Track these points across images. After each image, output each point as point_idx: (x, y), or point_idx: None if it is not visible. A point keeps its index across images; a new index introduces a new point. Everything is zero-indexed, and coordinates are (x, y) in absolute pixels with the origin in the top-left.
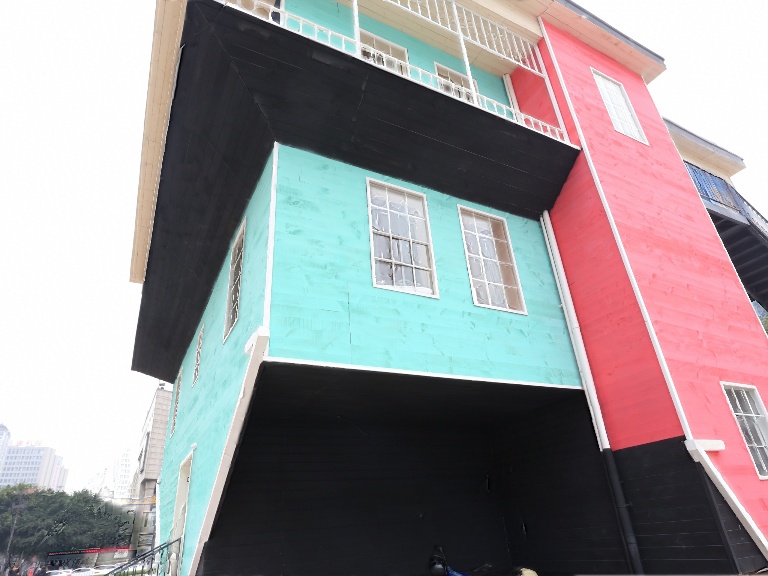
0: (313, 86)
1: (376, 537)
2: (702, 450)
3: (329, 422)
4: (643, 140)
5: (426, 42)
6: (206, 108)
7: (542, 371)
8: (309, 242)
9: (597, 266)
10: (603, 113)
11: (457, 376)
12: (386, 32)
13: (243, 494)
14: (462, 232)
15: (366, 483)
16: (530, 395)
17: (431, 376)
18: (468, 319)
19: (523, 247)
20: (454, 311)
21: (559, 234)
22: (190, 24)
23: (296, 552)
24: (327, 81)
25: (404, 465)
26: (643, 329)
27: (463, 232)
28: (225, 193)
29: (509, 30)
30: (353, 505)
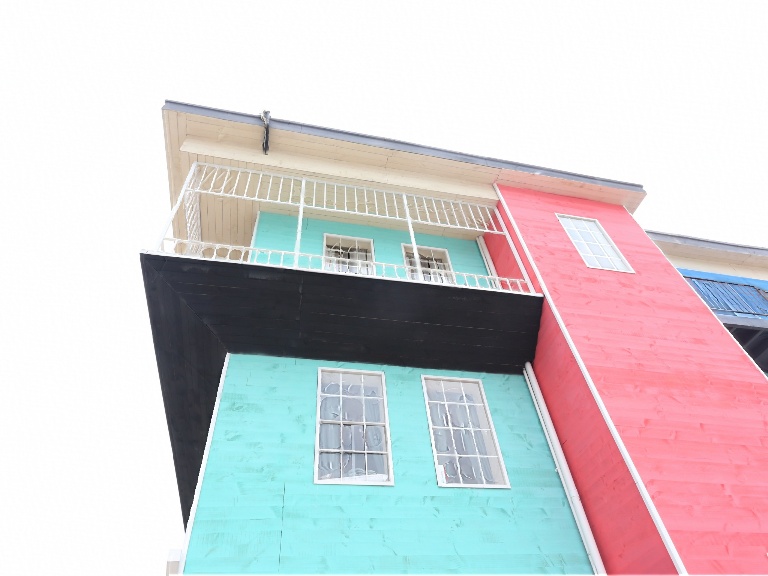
0: (254, 299)
1: None
2: None
3: None
4: (627, 269)
5: (393, 229)
6: (175, 334)
7: (534, 560)
8: (247, 446)
9: (581, 419)
10: (571, 254)
11: None
12: (353, 230)
13: None
14: (426, 404)
15: None
16: None
17: None
18: (431, 505)
19: (504, 407)
20: (413, 497)
21: (544, 386)
22: (147, 275)
23: None
24: (266, 293)
25: None
26: (636, 493)
27: (427, 404)
28: (209, 401)
29: (464, 202)
30: None
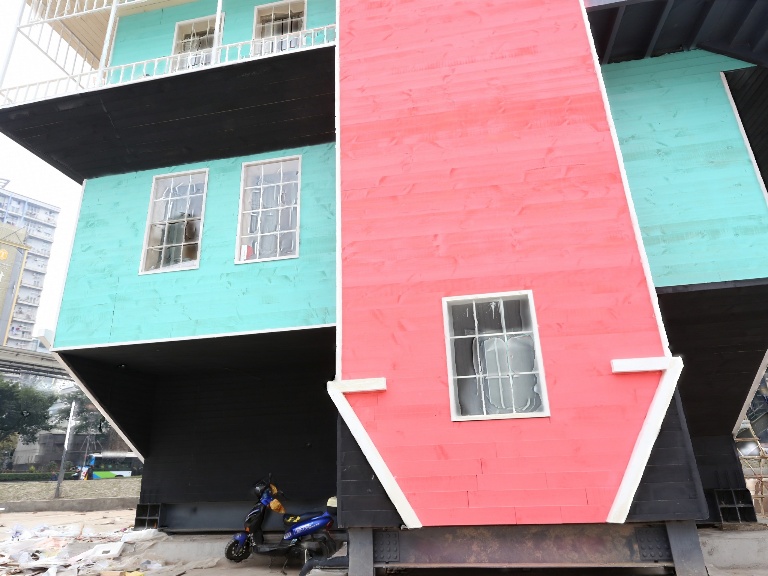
0: (76, 129)
1: (264, 461)
2: (336, 393)
3: (225, 372)
4: None
5: None
6: (63, 169)
7: (301, 314)
8: (96, 254)
9: None
10: None
11: (199, 336)
12: (206, 7)
13: (166, 429)
14: (240, 192)
15: (259, 418)
16: (312, 337)
17: (174, 341)
18: (225, 280)
19: (317, 180)
20: (212, 276)
21: None
22: None
23: (200, 469)
24: (81, 120)
25: (294, 402)
26: None
27: (241, 191)
28: None
29: None
30: (247, 436)
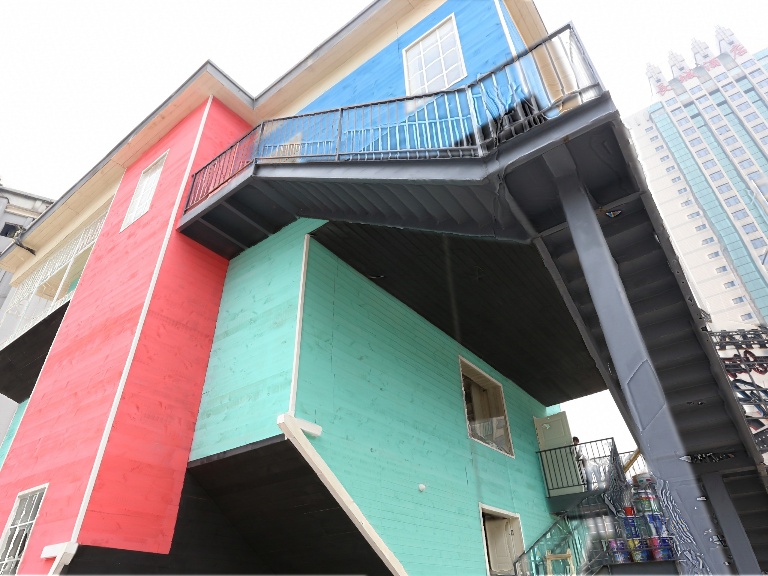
0: (4, 374)
1: None
2: None
3: None
4: None
5: None
6: None
7: None
8: None
9: None
10: None
11: None
12: None
13: None
14: None
15: None
16: None
17: None
18: None
19: None
20: None
21: None
22: None
23: None
24: (4, 369)
25: None
26: None
27: None
28: None
29: None
30: None
